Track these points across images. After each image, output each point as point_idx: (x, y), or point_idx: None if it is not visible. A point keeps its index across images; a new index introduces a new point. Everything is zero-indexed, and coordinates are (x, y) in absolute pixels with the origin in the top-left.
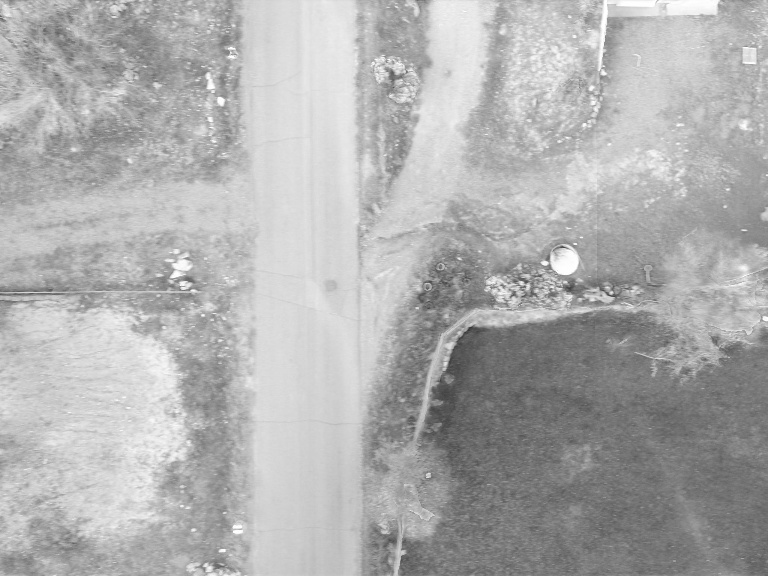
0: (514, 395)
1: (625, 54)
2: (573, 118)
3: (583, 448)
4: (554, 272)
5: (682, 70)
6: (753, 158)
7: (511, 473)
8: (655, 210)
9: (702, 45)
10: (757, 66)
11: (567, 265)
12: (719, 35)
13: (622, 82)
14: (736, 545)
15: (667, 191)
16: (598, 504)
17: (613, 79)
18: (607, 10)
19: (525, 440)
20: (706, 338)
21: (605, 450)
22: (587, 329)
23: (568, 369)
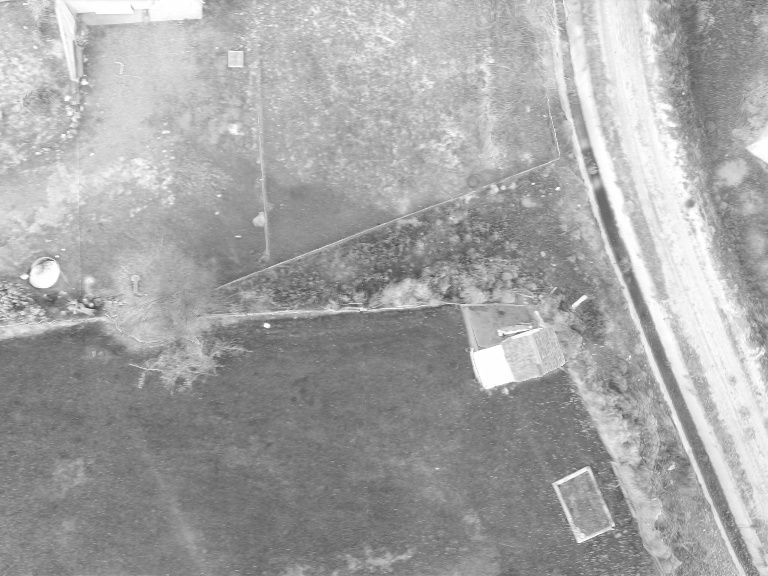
0: (3, 411)
1: (108, 62)
2: (50, 129)
3: (76, 462)
4: (23, 286)
5: (167, 76)
6: (246, 163)
7: (1, 490)
8: (141, 219)
9: (187, 50)
10: (246, 69)
11: (48, 278)
12: (204, 39)
13: (105, 91)
14: (231, 557)
15: (154, 200)
16: (92, 519)
17: (95, 88)
18: (61, 19)
19: (15, 456)
20: (196, 347)
21: (99, 464)
22: (77, 342)
23: (59, 383)
